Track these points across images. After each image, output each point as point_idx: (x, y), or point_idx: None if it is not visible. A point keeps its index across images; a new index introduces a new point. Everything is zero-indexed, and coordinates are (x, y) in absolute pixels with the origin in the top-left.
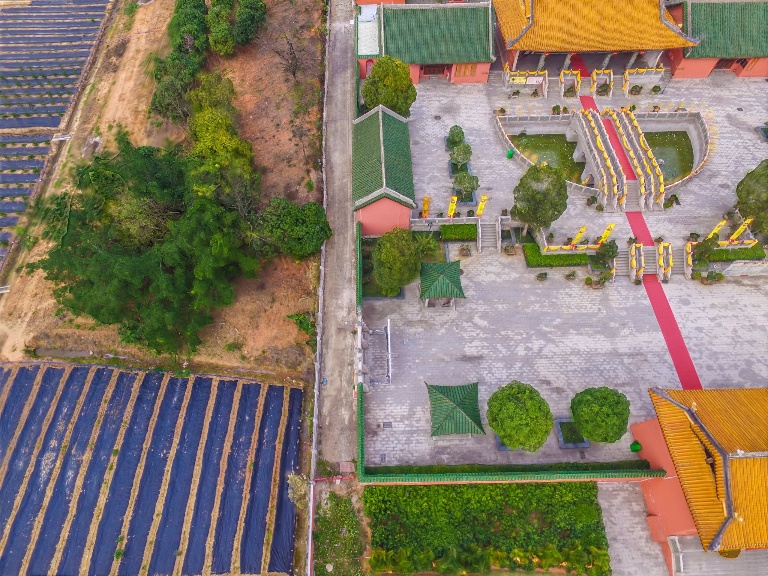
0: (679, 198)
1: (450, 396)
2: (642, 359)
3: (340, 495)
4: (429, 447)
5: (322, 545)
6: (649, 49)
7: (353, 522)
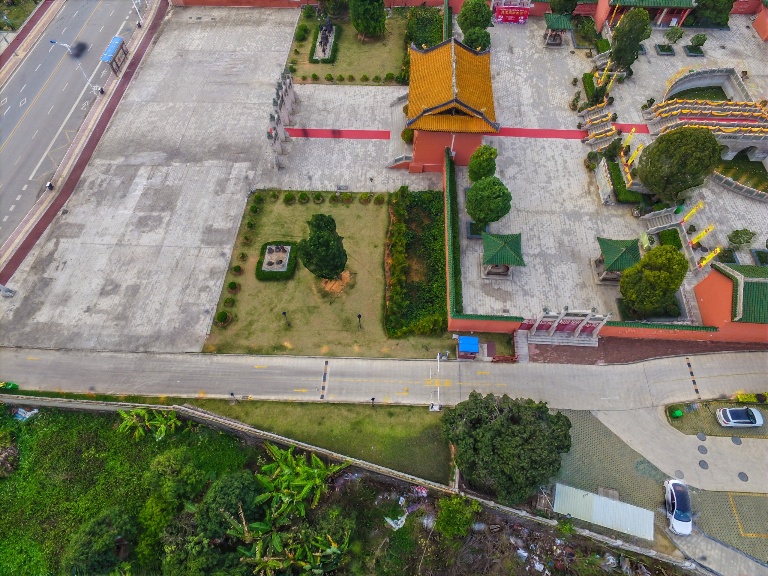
0: None
1: None
2: (517, 115)
3: (440, 12)
4: (461, 32)
5: (420, 7)
6: None
7: (428, 14)
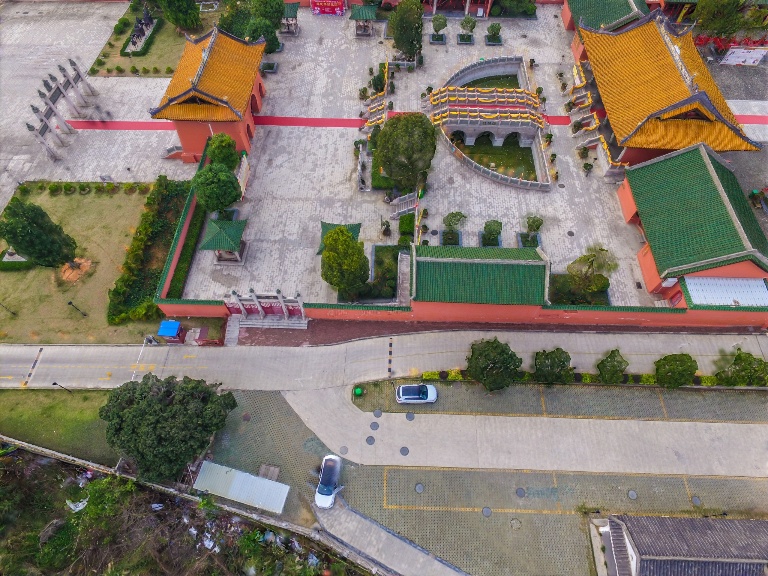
0: (436, 147)
1: (291, 6)
2: (304, 104)
3: None
4: None
5: None
6: (608, 116)
7: None
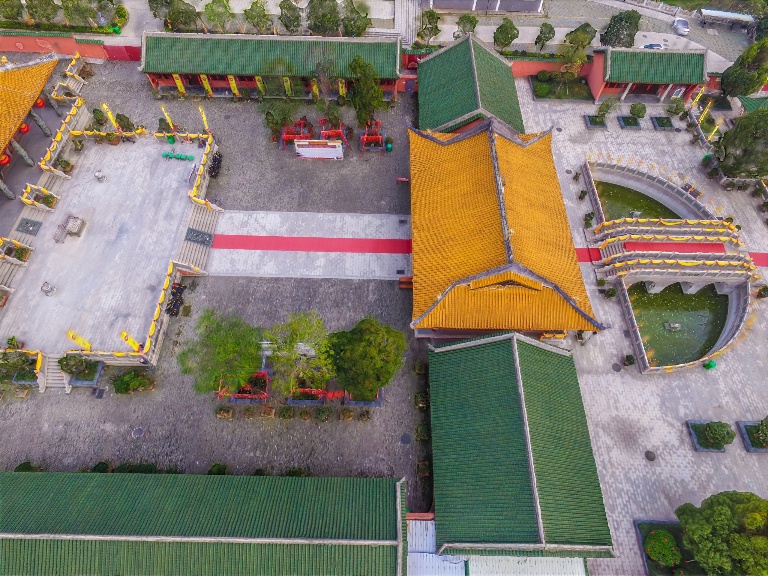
0: None
1: None
2: None
3: None
4: None
5: None
6: (556, 173)
7: None
